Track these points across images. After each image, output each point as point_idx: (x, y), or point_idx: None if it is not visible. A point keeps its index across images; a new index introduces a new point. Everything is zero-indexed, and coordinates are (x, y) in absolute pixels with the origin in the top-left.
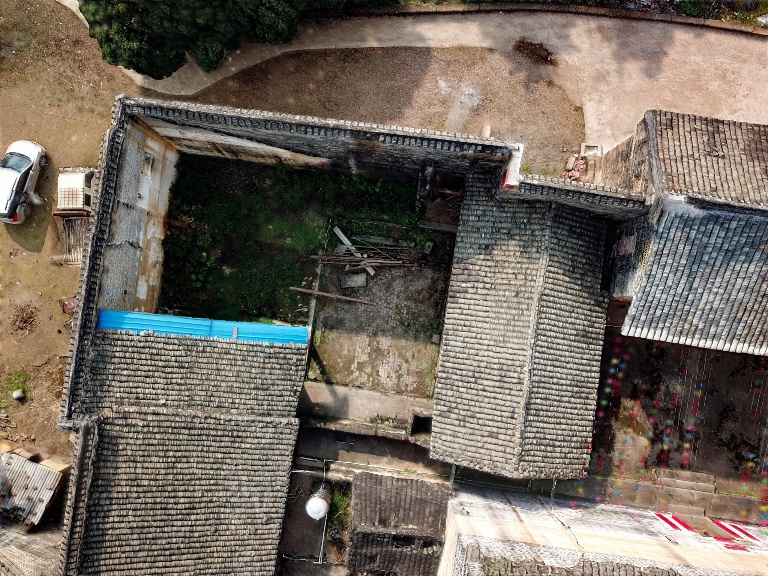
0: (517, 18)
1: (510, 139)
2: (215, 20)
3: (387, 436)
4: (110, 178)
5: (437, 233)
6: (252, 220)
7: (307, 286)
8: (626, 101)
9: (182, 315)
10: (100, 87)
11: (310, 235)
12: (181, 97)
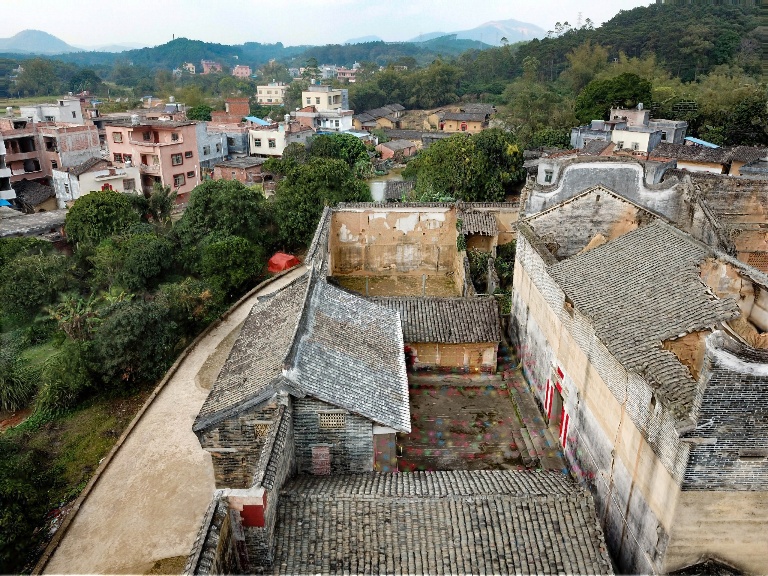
0: None
1: None
2: None
3: None
4: None
5: None
6: None
7: None
8: (160, 524)
9: None
10: None
11: None
12: None
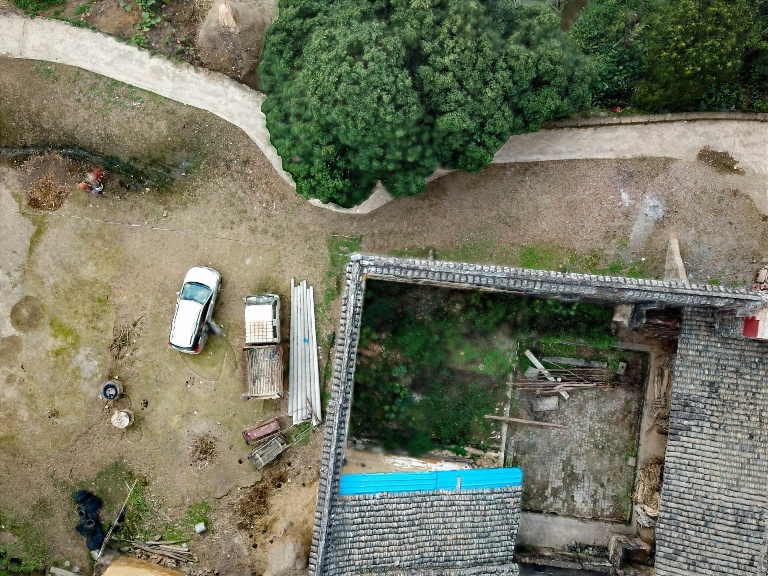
0: (702, 127)
1: (698, 251)
2: (423, 156)
3: (594, 569)
4: (353, 345)
5: (629, 352)
6: (443, 347)
7: (500, 412)
8: None
9: (372, 446)
10: (273, 208)
11: (501, 359)
12: (356, 216)
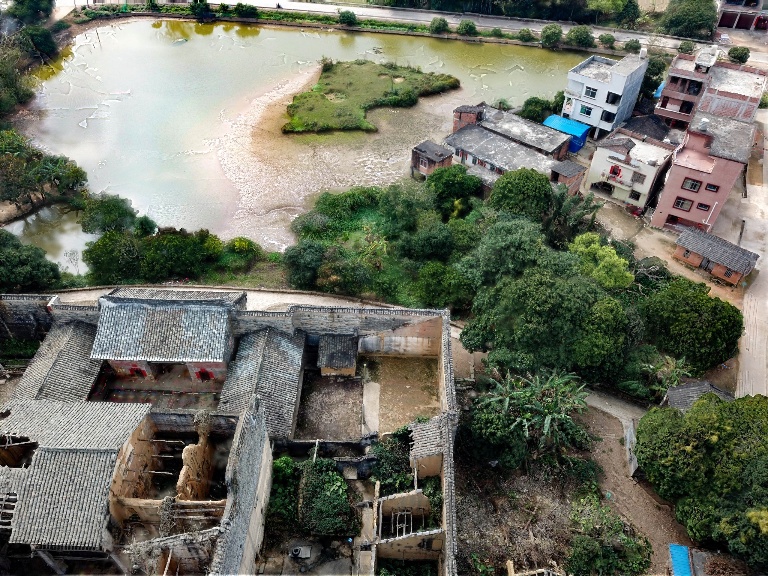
0: None
1: None
2: None
3: None
4: None
5: None
6: None
7: None
8: None
9: None
10: None
11: None
12: None
